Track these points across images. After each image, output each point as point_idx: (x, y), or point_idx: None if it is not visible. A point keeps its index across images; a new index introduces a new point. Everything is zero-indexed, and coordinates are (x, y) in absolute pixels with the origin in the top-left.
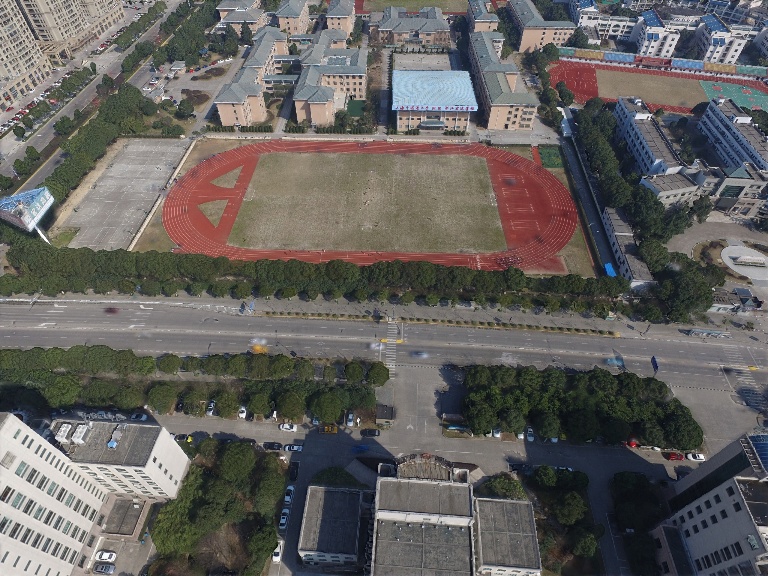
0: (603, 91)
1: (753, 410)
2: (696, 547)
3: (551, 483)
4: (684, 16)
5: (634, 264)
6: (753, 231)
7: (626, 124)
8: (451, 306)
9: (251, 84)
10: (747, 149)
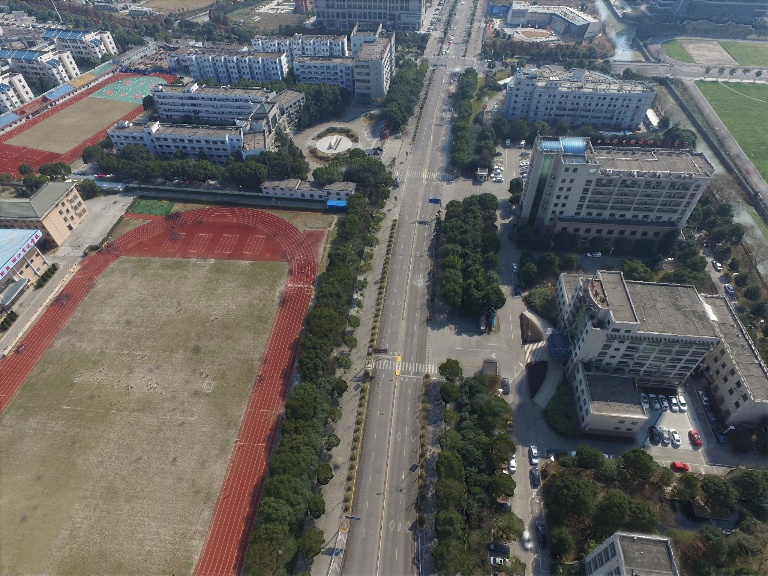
0: (55, 149)
1: (456, 180)
2: (571, 210)
3: (536, 268)
4: None
5: (336, 187)
6: (303, 133)
7: (148, 143)
8: (356, 313)
9: None
10: (227, 100)
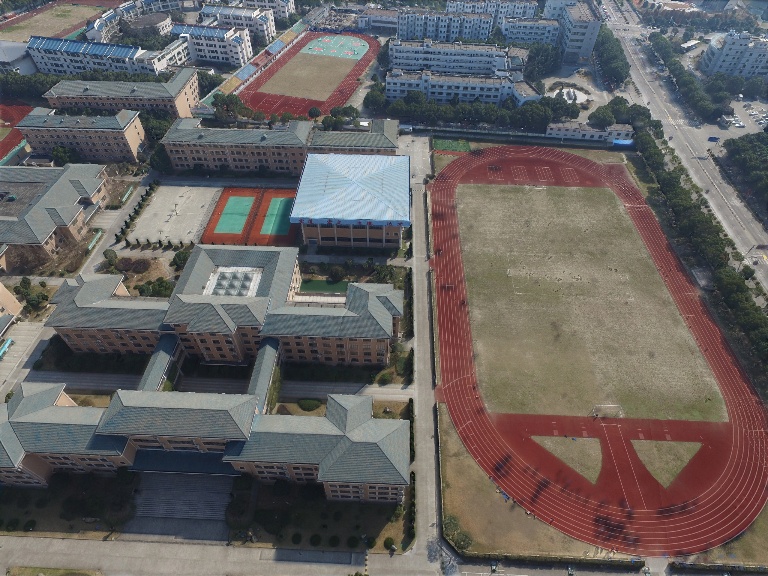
0: (313, 97)
1: None
2: None
3: None
4: (164, 22)
5: (617, 128)
6: None
7: (422, 90)
8: None
9: (347, 408)
10: (463, 55)
